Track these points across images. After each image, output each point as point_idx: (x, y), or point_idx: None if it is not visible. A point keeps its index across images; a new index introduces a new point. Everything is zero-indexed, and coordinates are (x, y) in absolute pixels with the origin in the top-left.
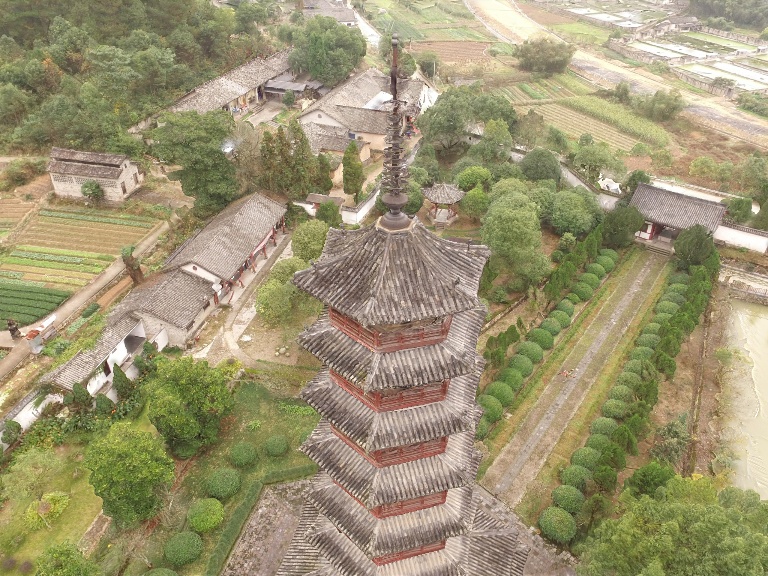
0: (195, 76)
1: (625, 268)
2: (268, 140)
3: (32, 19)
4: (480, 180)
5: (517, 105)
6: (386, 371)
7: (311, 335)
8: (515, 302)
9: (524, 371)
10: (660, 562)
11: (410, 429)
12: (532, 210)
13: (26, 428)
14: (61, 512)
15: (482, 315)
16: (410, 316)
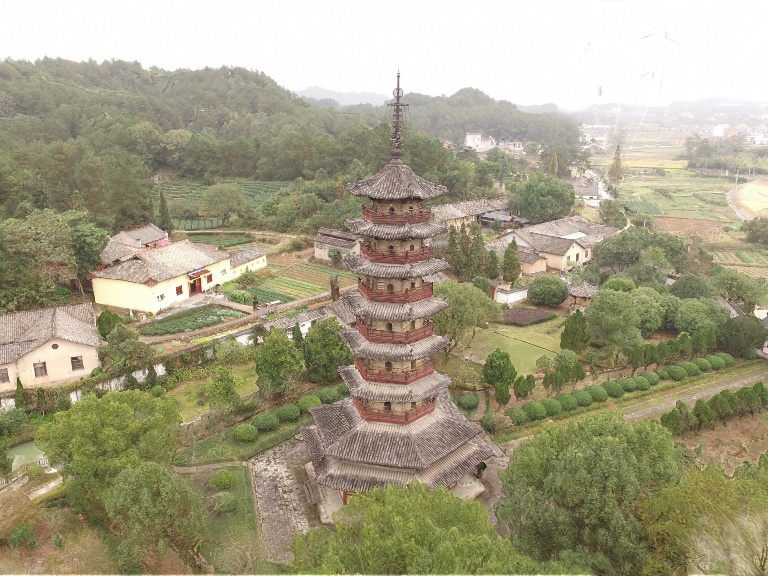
0: (433, 204)
1: (738, 371)
2: (452, 232)
3: (342, 162)
4: (622, 287)
5: (722, 264)
6: (372, 230)
7: (352, 222)
8: (609, 368)
9: (580, 400)
10: (556, 444)
11: (383, 272)
12: (653, 308)
13: None
14: (237, 384)
15: (444, 229)
16: (383, 196)
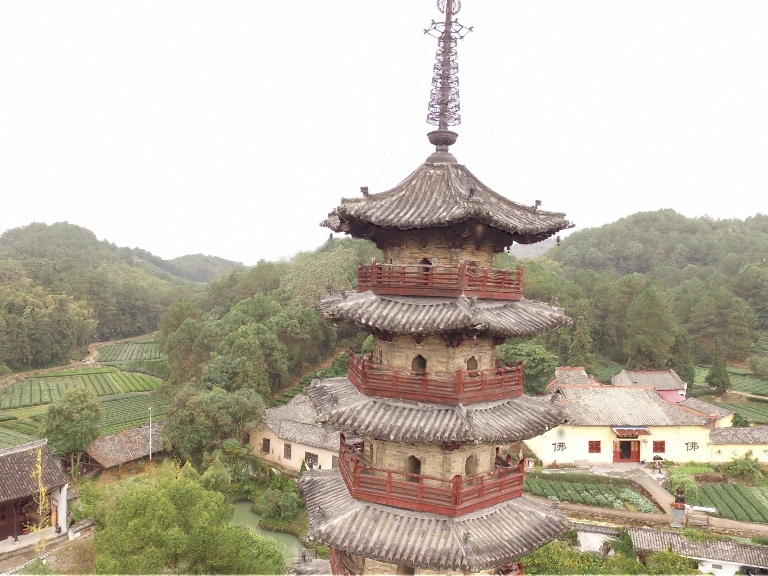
0: None
1: None
2: None
3: None
4: None
5: None
6: None
7: None
8: None
9: None
10: None
11: None
12: None
13: (585, 550)
14: None
15: None
16: None
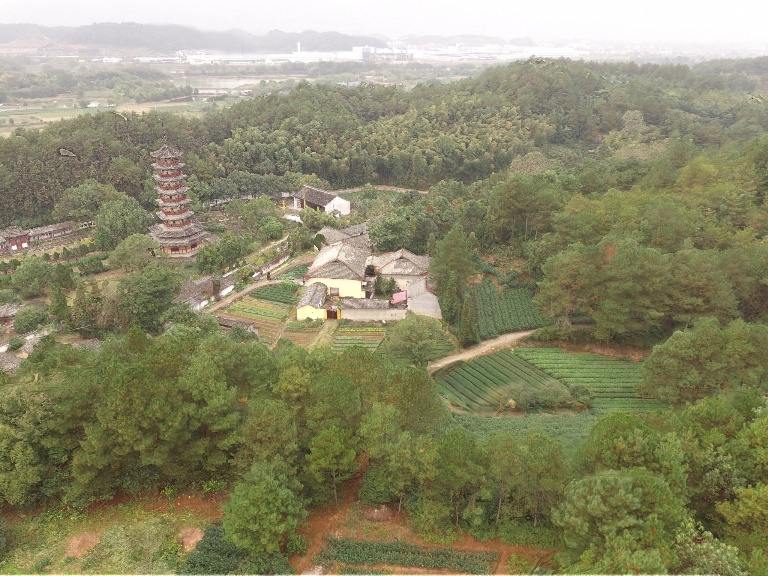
0: None
1: None
2: None
3: None
4: None
5: None
6: None
7: None
8: None
9: None
10: None
11: None
12: None
13: None
14: None
15: None
16: None
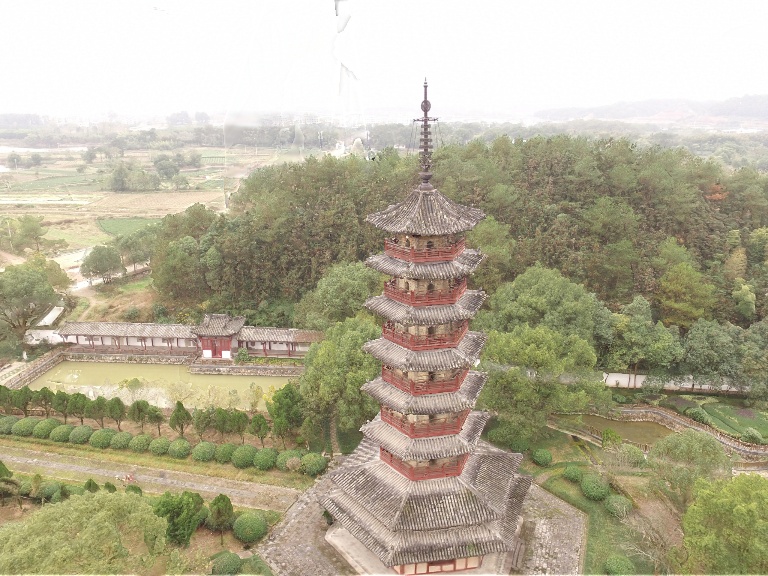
0: None
1: None
2: None
3: None
4: None
5: None
6: None
7: None
8: None
9: None
10: None
11: None
12: None
13: None
14: None
15: None
16: None
